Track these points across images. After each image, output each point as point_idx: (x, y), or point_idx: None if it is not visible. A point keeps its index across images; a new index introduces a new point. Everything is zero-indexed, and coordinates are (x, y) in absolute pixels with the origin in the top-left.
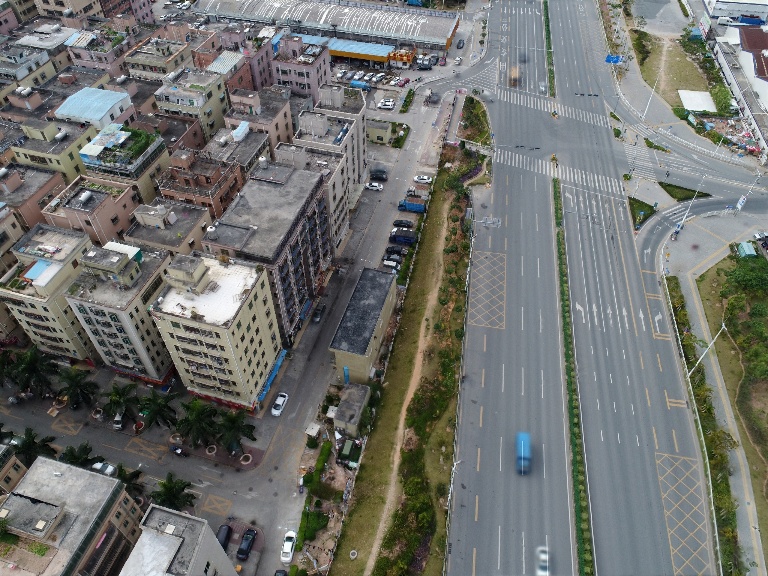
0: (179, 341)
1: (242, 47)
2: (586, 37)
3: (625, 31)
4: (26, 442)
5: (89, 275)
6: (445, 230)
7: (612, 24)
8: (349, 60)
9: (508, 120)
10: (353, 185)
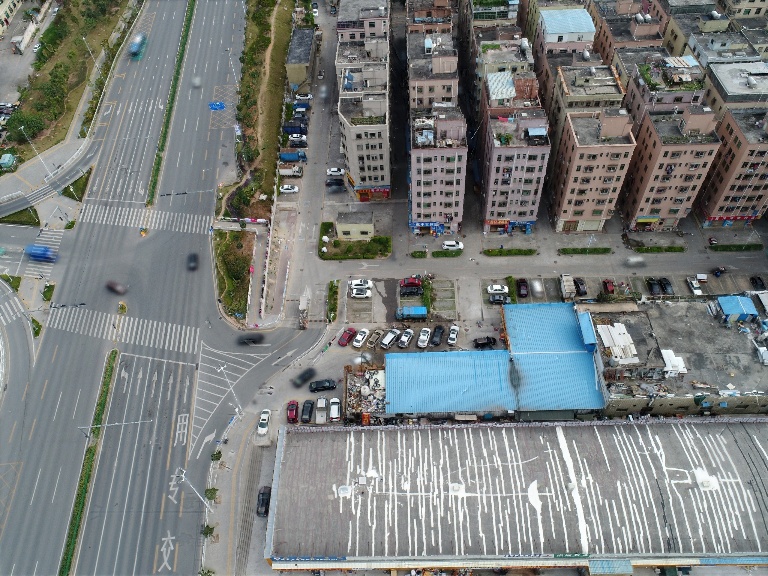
0: None
1: None
2: None
3: None
4: None
5: None
6: (259, 130)
7: None
8: None
9: (189, 285)
10: None
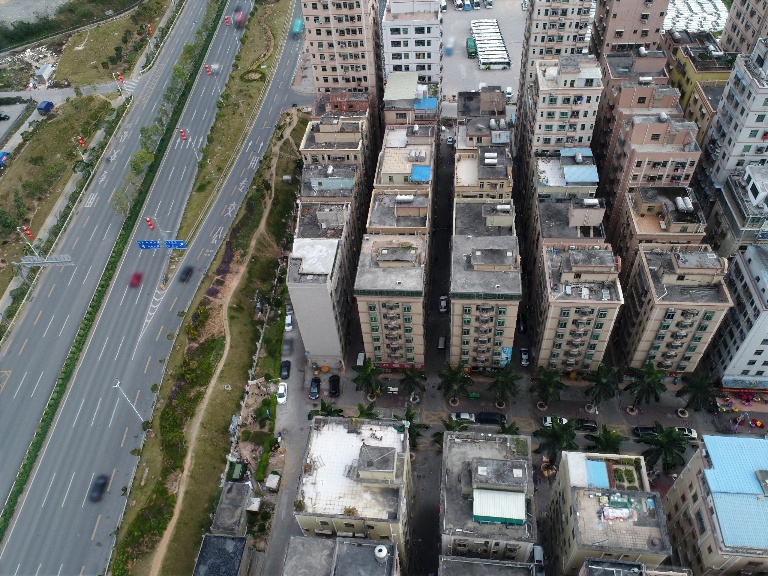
0: None
1: None
2: None
3: None
4: (504, 373)
5: None
6: None
7: None
8: None
9: None
10: None
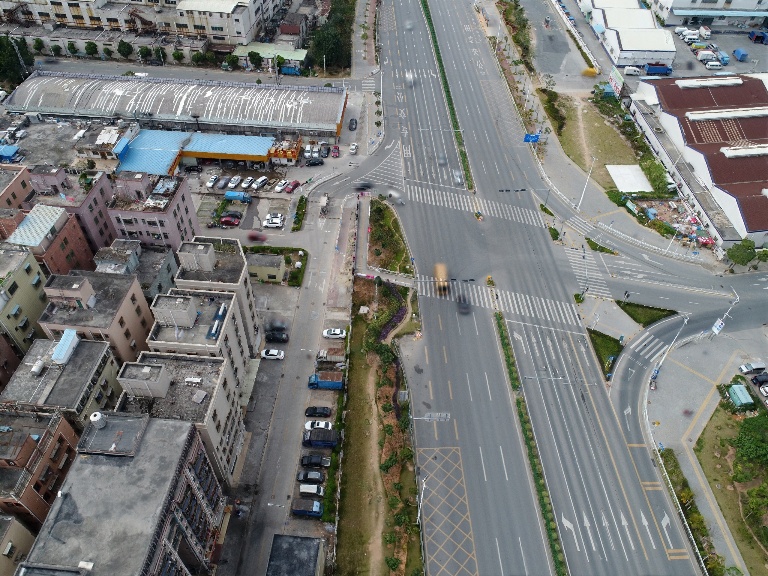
0: None
1: (64, 188)
2: (492, 103)
3: (535, 96)
4: None
5: None
6: (375, 422)
7: (517, 83)
8: (220, 161)
9: (426, 229)
10: (244, 368)
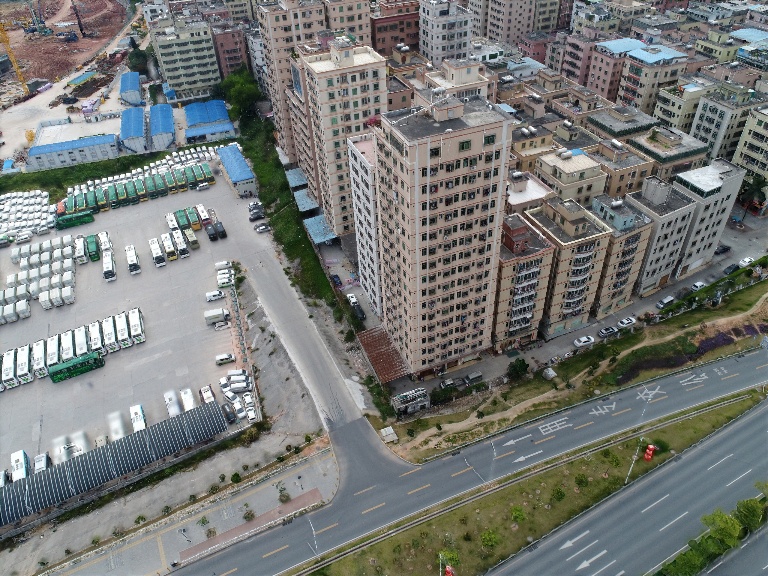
0: (752, 137)
1: None
2: None
3: None
4: None
5: (719, 93)
6: None
7: None
8: None
9: None
10: None
